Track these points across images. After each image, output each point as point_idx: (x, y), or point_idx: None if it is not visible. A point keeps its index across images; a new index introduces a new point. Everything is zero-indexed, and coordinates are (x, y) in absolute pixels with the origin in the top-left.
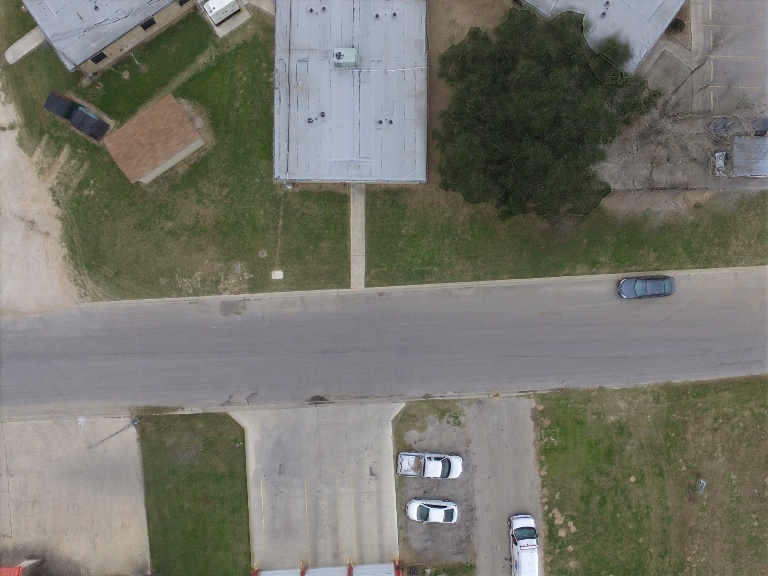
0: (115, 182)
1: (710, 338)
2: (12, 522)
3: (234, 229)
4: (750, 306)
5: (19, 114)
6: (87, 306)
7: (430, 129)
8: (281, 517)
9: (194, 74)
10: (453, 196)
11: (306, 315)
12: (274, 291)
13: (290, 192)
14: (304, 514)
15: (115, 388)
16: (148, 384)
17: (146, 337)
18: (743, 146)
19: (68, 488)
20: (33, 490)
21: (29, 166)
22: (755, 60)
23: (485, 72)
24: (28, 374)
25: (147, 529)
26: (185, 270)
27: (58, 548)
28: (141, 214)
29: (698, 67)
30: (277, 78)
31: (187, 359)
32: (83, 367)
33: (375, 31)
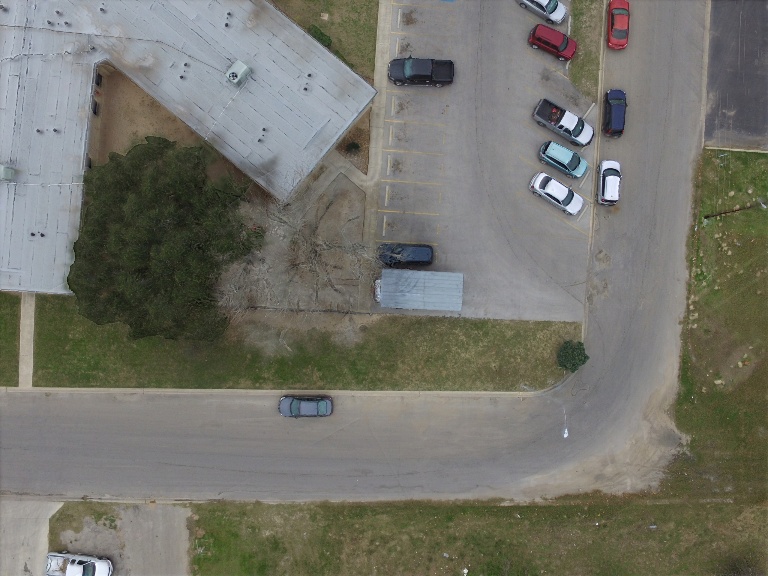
0: None
1: (371, 460)
2: None
3: None
4: (414, 431)
5: None
6: None
7: None
8: None
9: None
10: None
11: None
12: None
13: None
14: None
15: None
16: None
17: None
18: (389, 279)
19: None
20: None
21: None
22: (433, 187)
23: (103, 202)
24: None
25: None
26: None
27: None
28: None
29: (329, 204)
30: None
31: None
32: None
33: (35, 145)
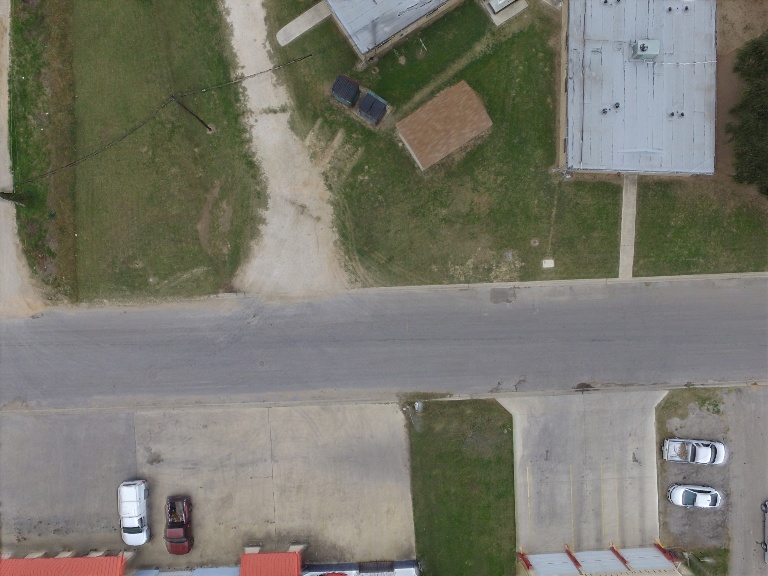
0: (390, 168)
1: None
2: (276, 507)
3: (507, 217)
4: None
5: (291, 97)
6: (357, 292)
7: (720, 122)
8: (546, 502)
9: (471, 61)
10: (721, 189)
11: (575, 303)
12: (544, 279)
13: (565, 182)
14: (569, 499)
15: (384, 374)
16: (417, 370)
17: (417, 323)
18: None
19: (334, 473)
20: (298, 475)
21: (301, 150)
22: None
23: None
24: (296, 359)
25: (413, 514)
26: (458, 257)
27: (323, 533)
28: (416, 200)
29: None
30: (571, 68)
31: (457, 346)
32: (352, 353)
33: (667, 24)
